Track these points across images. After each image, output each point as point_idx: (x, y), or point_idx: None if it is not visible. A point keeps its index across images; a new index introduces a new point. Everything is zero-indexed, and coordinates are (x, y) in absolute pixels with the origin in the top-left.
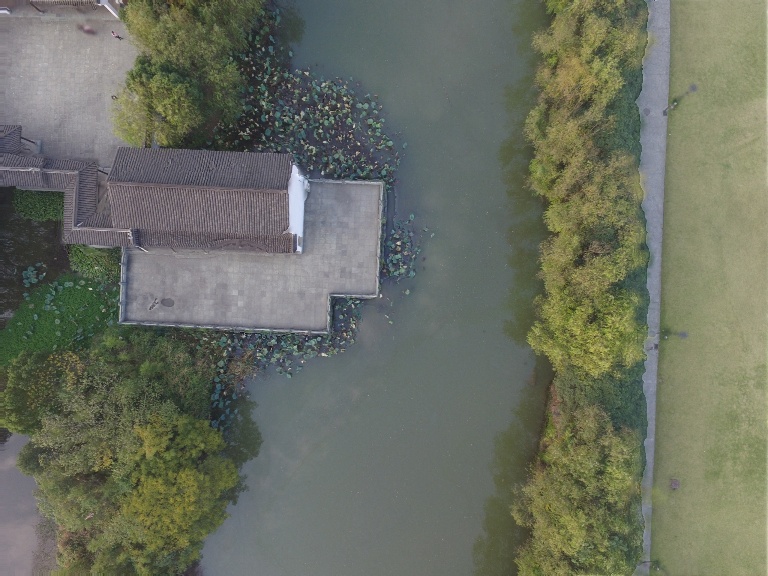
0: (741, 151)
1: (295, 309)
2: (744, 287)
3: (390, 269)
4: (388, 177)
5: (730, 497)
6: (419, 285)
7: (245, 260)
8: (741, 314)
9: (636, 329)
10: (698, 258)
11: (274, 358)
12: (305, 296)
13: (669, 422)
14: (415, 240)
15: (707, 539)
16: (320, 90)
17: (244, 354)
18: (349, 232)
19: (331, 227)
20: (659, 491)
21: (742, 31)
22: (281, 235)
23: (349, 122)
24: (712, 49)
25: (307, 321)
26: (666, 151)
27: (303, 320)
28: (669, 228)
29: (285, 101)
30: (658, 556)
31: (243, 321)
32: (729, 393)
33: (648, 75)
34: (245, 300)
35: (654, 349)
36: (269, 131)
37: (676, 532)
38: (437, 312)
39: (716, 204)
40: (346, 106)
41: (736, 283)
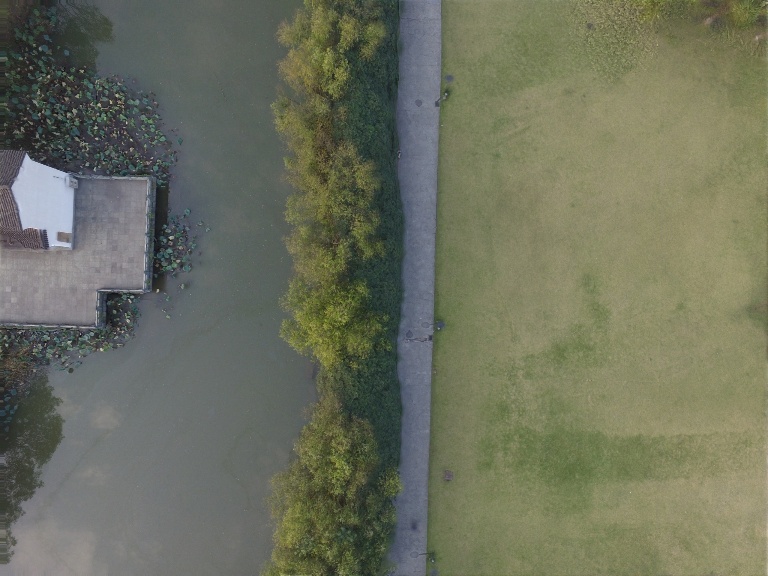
0: (511, 141)
1: (67, 305)
2: (513, 277)
3: (162, 264)
4: (161, 172)
5: (502, 488)
6: (196, 279)
7: (18, 257)
8: (509, 304)
9: (376, 319)
10: (468, 248)
11: (49, 353)
12: (77, 292)
13: (443, 413)
14: (191, 235)
15: (482, 531)
16: (93, 87)
17: (20, 350)
18: (120, 227)
19: (102, 223)
20: (434, 483)
21: (513, 20)
22: (24, 231)
23: (123, 118)
24: (482, 39)
25: (79, 316)
26: (439, 142)
27: (75, 315)
28: (442, 219)
29: (57, 99)
30: (434, 548)
31: (16, 317)
32: (499, 383)
33: (419, 66)
34: (18, 296)
35: (428, 340)
36: (40, 129)
37: (451, 524)
38: (214, 306)
39: (486, 194)
40: (119, 103)
41: (505, 273)
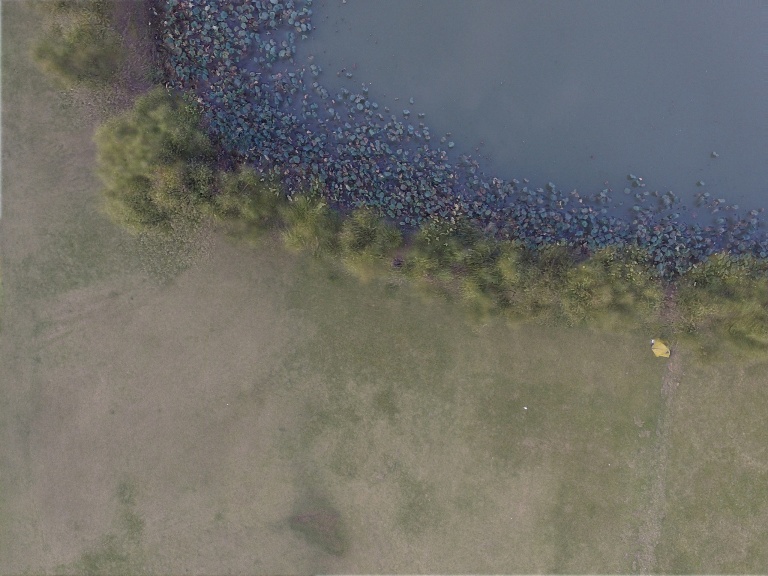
0: (52, 345)
1: None
2: (48, 485)
3: None
4: None
5: None
6: None
7: None
8: (42, 513)
9: None
10: (6, 454)
11: None
12: None
13: None
14: None
15: None
16: None
17: None
18: None
19: None
20: None
21: (60, 220)
22: None
23: None
24: (26, 240)
25: None
26: None
27: None
28: None
29: None
30: None
31: None
32: None
33: None
34: None
35: None
36: None
37: None
38: None
39: (25, 399)
40: None
41: (40, 481)
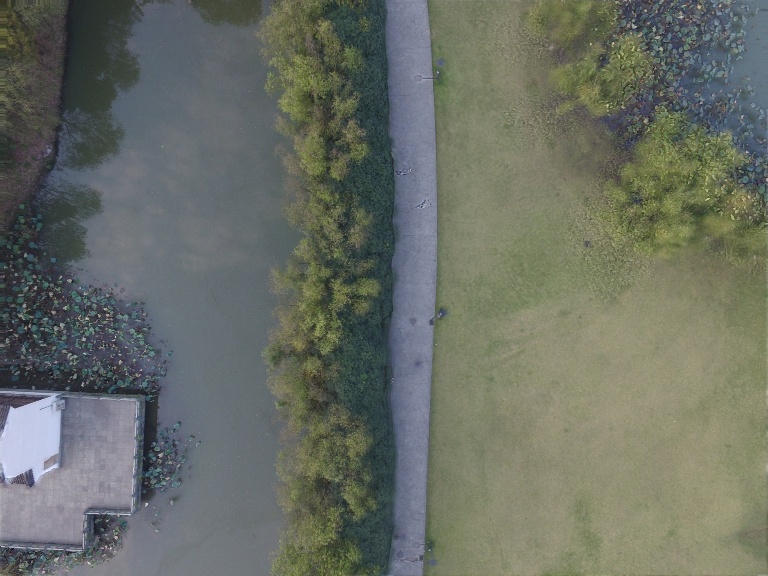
0: (505, 364)
1: (54, 523)
2: (505, 503)
3: (151, 482)
4: (150, 388)
5: None
6: (185, 493)
7: None
8: (501, 531)
9: (366, 572)
10: (460, 473)
11: (35, 570)
12: (64, 510)
13: None
14: (181, 448)
15: None
16: (81, 300)
17: (6, 566)
18: (108, 446)
19: (90, 441)
20: None
21: (510, 240)
22: None
23: (112, 331)
24: (478, 259)
25: (66, 535)
26: (432, 361)
27: (62, 534)
28: (434, 439)
29: (44, 313)
30: None
31: (2, 535)
32: None
33: (414, 284)
34: (4, 514)
35: (419, 560)
36: (26, 344)
37: None
38: (203, 521)
39: (479, 418)
40: (107, 316)
41: (497, 499)
